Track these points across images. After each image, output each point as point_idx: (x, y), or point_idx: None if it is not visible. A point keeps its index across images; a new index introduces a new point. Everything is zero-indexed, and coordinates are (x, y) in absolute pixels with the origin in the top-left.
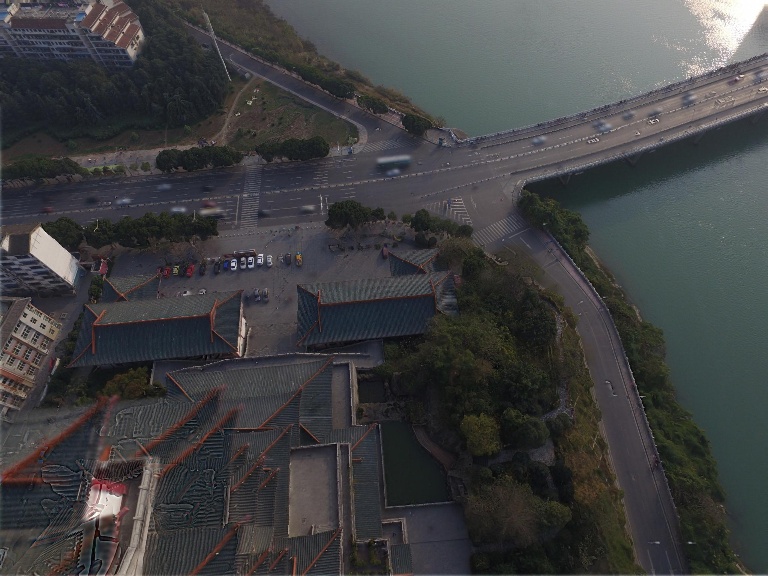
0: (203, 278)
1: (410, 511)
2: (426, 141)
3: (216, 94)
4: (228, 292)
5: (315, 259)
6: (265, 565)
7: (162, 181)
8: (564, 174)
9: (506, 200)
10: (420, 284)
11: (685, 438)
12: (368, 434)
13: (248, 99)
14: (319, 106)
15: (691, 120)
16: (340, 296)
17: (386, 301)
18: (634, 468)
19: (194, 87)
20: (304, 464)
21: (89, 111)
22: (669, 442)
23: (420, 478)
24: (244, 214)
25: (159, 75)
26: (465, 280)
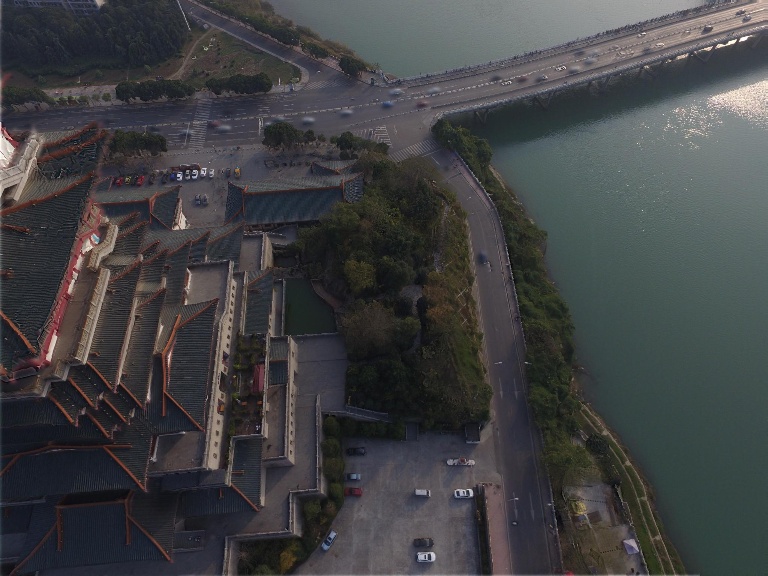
0: (152, 187)
1: (302, 340)
2: (360, 81)
3: (175, 39)
4: (168, 187)
5: (252, 173)
6: (137, 269)
7: (121, 111)
8: (478, 110)
9: (424, 128)
10: (333, 182)
11: (547, 304)
12: (267, 274)
13: (205, 46)
14: (268, 52)
15: (594, 68)
16: (263, 189)
17: (301, 192)
18: (498, 322)
19: (154, 31)
20: (203, 275)
21: (58, 50)
22: (529, 302)
23: (314, 318)
24: (193, 137)
25: (123, 20)
26: (373, 180)
